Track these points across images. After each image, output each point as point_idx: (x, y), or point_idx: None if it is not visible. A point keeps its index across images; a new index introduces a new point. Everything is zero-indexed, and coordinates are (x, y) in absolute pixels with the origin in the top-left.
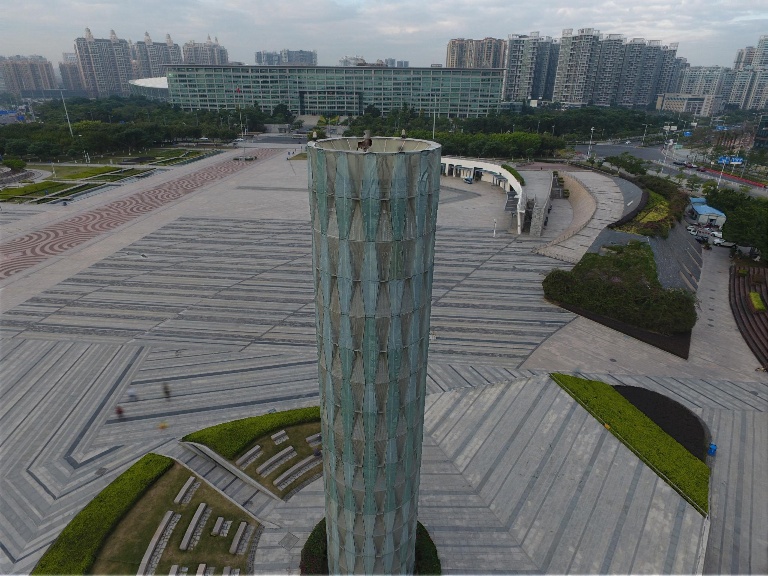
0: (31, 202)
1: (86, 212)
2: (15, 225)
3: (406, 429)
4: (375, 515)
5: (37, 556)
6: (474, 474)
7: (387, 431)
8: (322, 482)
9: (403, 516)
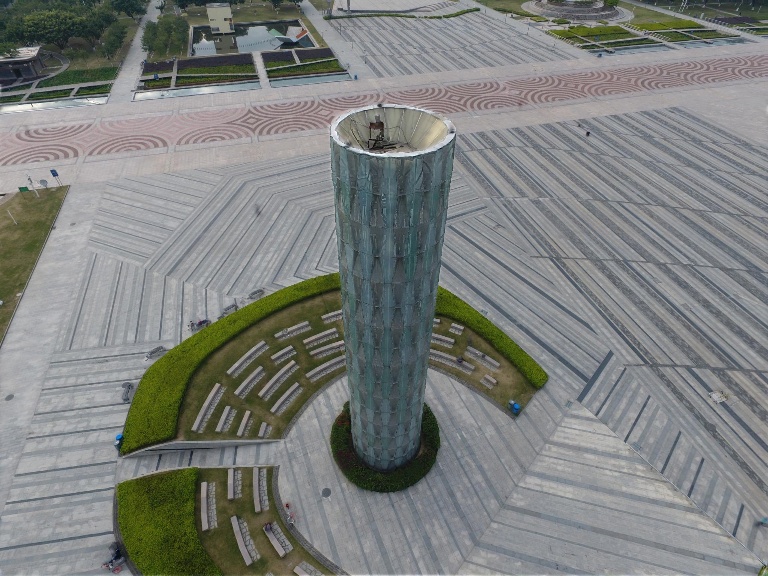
0: (578, 46)
1: (604, 70)
2: (544, 65)
3: (365, 359)
4: (351, 393)
5: (322, 274)
6: (523, 498)
7: (352, 347)
8: (439, 377)
9: (369, 416)
